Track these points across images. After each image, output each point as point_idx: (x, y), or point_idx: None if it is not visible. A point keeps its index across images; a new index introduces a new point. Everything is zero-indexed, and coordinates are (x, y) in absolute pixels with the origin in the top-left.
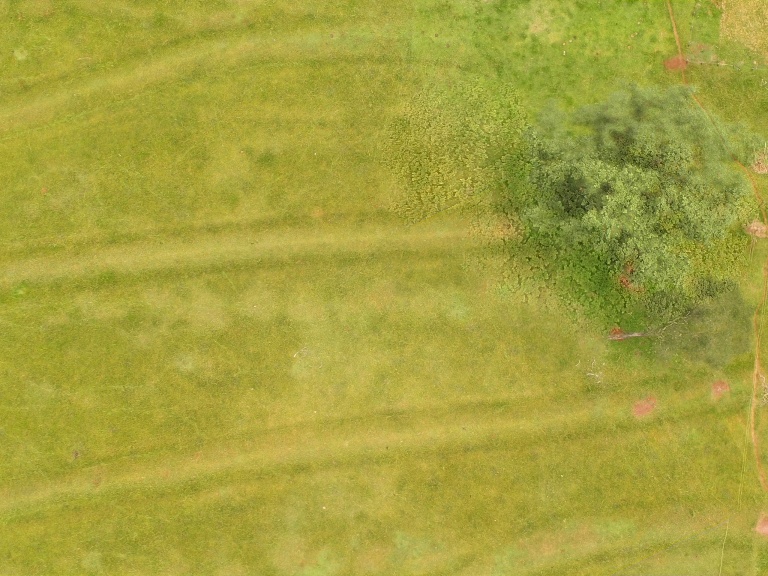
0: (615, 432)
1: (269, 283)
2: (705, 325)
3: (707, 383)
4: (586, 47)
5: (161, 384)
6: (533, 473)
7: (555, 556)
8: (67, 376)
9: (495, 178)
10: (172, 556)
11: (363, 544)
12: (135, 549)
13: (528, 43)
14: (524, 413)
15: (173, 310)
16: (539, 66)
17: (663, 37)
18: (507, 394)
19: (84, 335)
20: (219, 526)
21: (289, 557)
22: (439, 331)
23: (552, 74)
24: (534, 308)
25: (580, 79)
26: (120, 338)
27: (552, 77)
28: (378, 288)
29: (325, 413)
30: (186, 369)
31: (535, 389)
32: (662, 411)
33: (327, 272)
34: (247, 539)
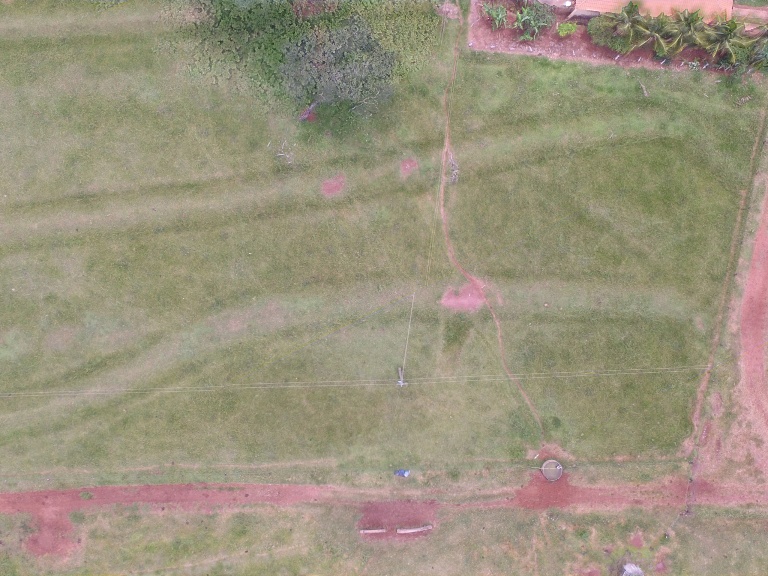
0: (304, 210)
1: None
2: (395, 104)
3: (396, 161)
4: None
5: None
6: (223, 252)
7: (242, 331)
8: None
9: None
10: None
11: (52, 324)
12: None
13: None
14: (215, 194)
15: None
16: None
17: None
18: (198, 176)
19: None
20: None
21: None
22: (129, 114)
23: None
24: (224, 90)
25: None
26: None
27: None
28: (68, 72)
29: (15, 197)
30: None
31: (226, 170)
32: (351, 189)
33: (17, 57)
34: None
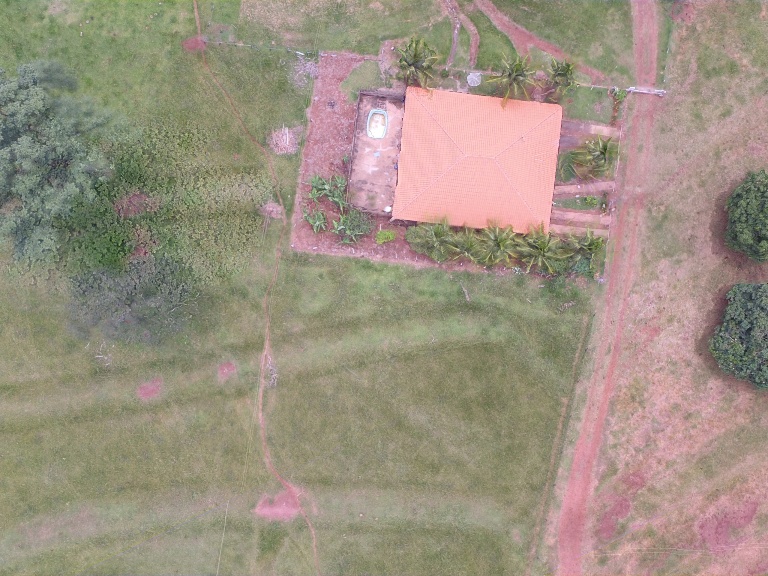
0: (121, 414)
1: None
2: (214, 306)
3: (214, 364)
4: (103, 28)
5: None
6: (37, 456)
7: (53, 539)
8: None
9: (10, 160)
10: None
11: None
12: None
13: (46, 24)
14: (31, 396)
15: None
16: (58, 47)
17: (183, 17)
18: (15, 377)
19: None
20: None
21: None
22: None
23: (71, 55)
24: (43, 290)
25: (99, 60)
26: None
27: (71, 58)
28: None
29: None
30: None
31: (43, 372)
32: (168, 393)
33: None
34: None
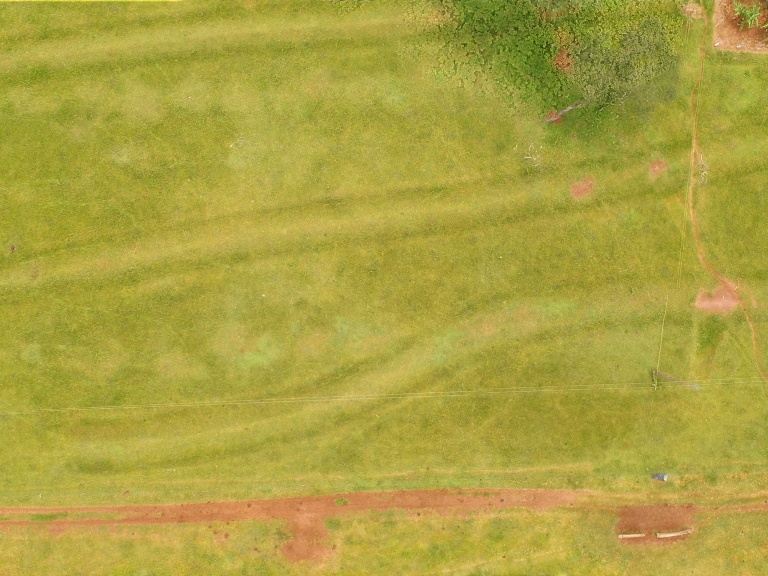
0: (553, 213)
1: (203, 74)
2: (642, 106)
3: (645, 163)
4: None
5: (97, 177)
6: (472, 256)
7: (495, 336)
8: (2, 171)
9: None
10: (112, 346)
11: (303, 330)
12: (74, 340)
13: None
14: (462, 197)
15: (107, 102)
16: None
17: None
18: (445, 179)
19: (18, 130)
20: (158, 316)
21: (229, 343)
22: (375, 118)
23: None
24: (470, 93)
25: None
26: (54, 132)
27: None
28: (313, 76)
29: (263, 202)
30: (122, 161)
31: (473, 174)
32: (600, 192)
33: (262, 62)
34: (186, 327)
